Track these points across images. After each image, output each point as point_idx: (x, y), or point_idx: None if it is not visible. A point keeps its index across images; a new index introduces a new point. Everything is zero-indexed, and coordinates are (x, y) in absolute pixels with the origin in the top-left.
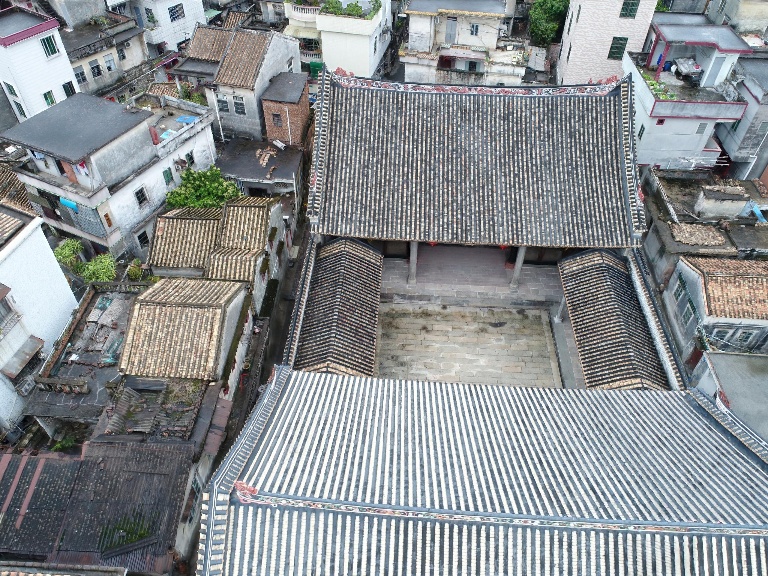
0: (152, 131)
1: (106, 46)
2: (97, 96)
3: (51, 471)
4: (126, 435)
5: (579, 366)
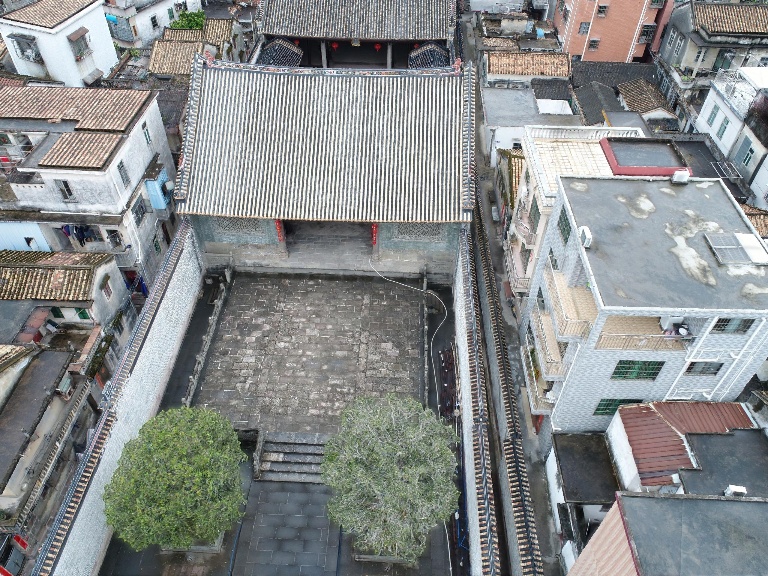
0: None
1: None
2: None
3: None
4: None
5: None
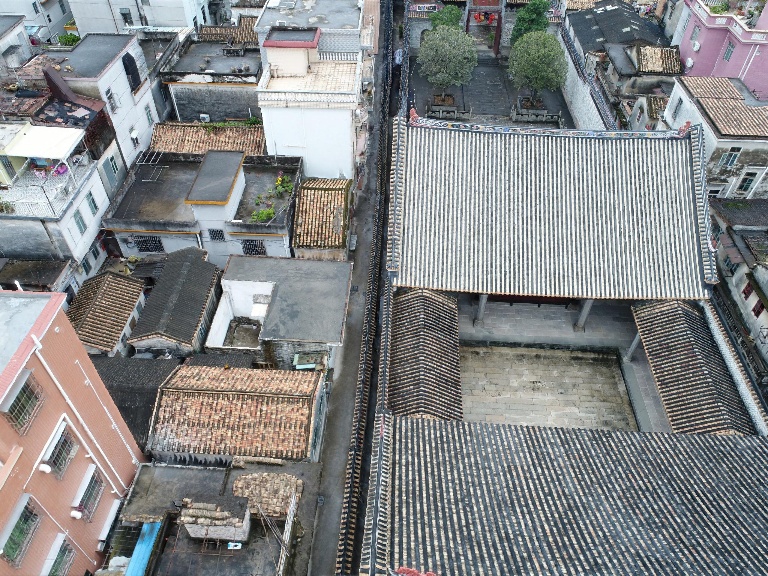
0: None
1: None
2: None
3: None
4: None
5: None
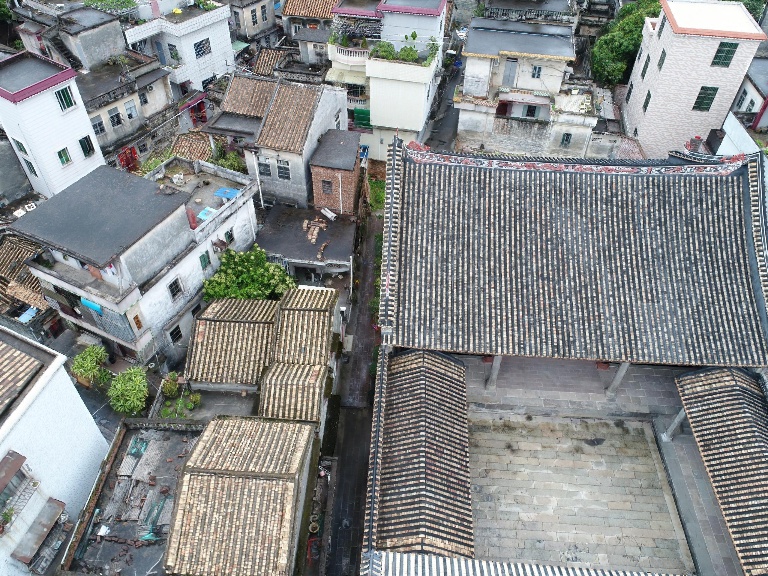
0: (190, 214)
1: (127, 92)
2: (116, 147)
3: None
4: None
5: (701, 503)
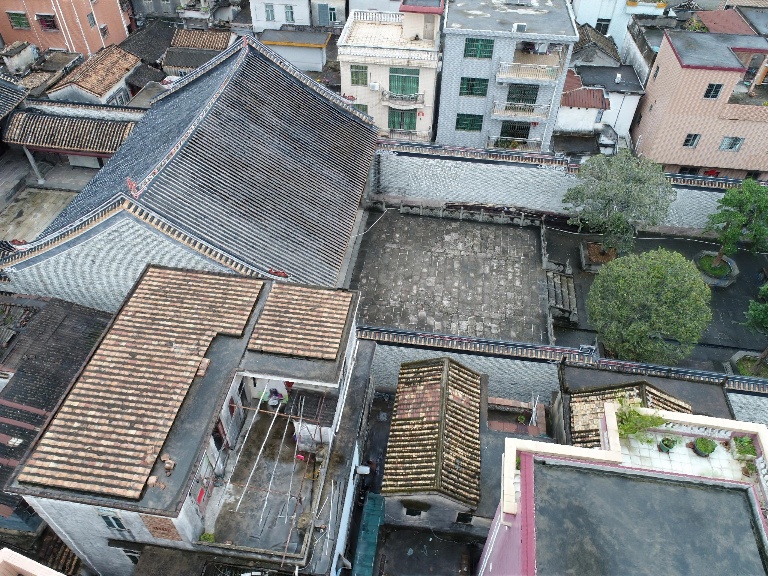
0: None
1: None
2: None
3: (13, 393)
4: (7, 349)
5: None
